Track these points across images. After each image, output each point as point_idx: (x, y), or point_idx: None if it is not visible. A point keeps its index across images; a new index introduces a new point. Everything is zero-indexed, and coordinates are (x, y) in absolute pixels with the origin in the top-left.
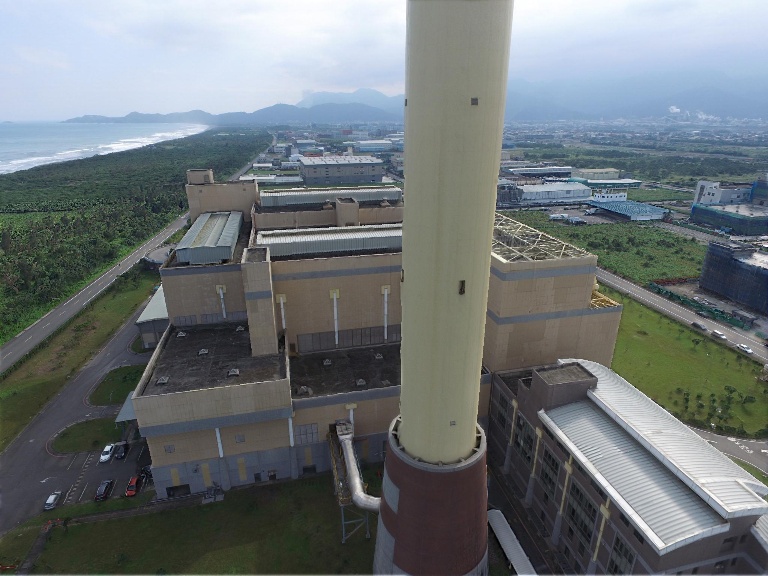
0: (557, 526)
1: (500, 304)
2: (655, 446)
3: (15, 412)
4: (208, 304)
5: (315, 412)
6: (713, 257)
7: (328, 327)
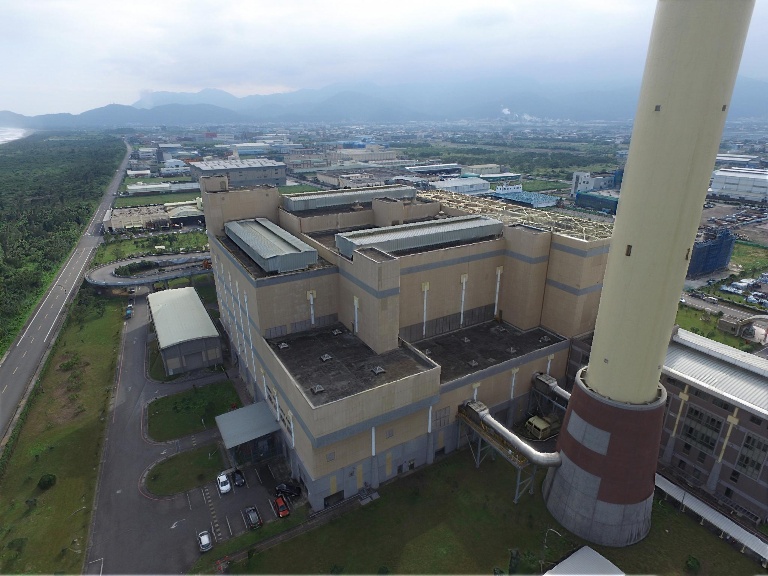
0: (670, 447)
1: (581, 278)
2: (753, 365)
3: (70, 467)
4: (298, 312)
5: (449, 396)
6: None
7: (418, 319)
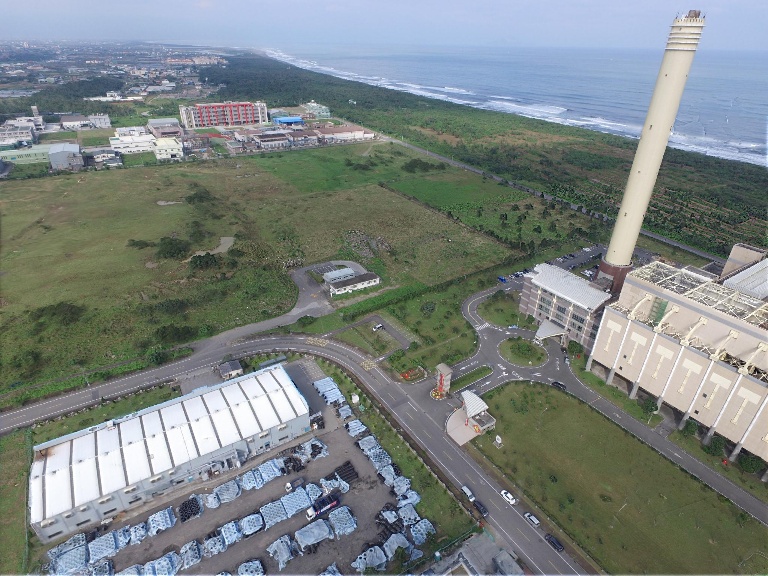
0: None
1: None
2: None
3: None
4: None
5: None
6: None
7: None
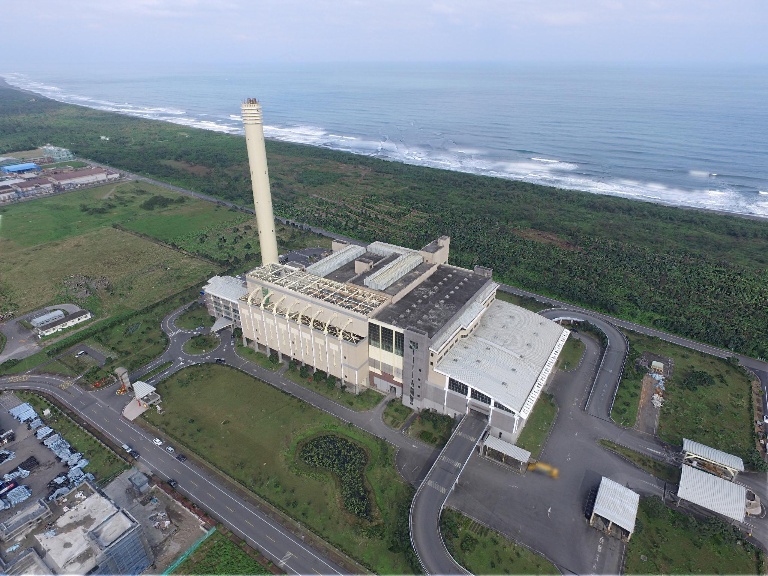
0: None
1: None
2: None
3: None
4: None
5: None
6: None
7: None
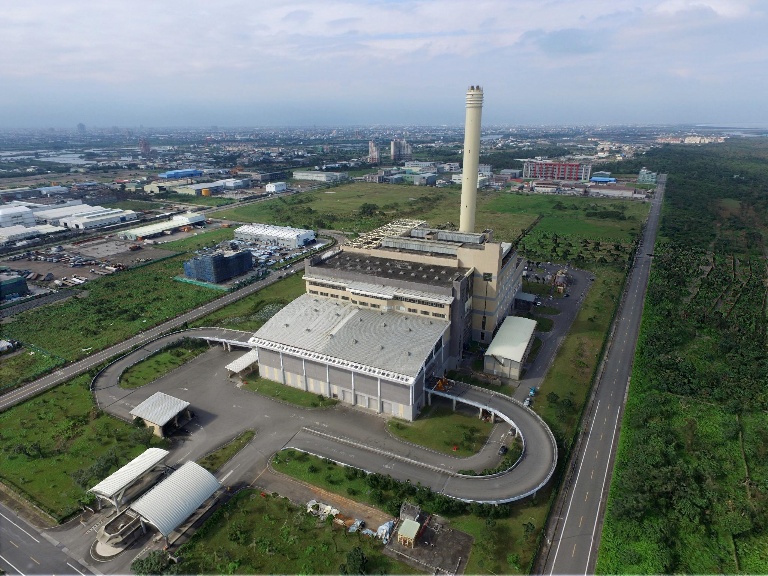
0: None
1: None
2: None
3: (583, 323)
4: None
5: None
6: (217, 263)
7: None
